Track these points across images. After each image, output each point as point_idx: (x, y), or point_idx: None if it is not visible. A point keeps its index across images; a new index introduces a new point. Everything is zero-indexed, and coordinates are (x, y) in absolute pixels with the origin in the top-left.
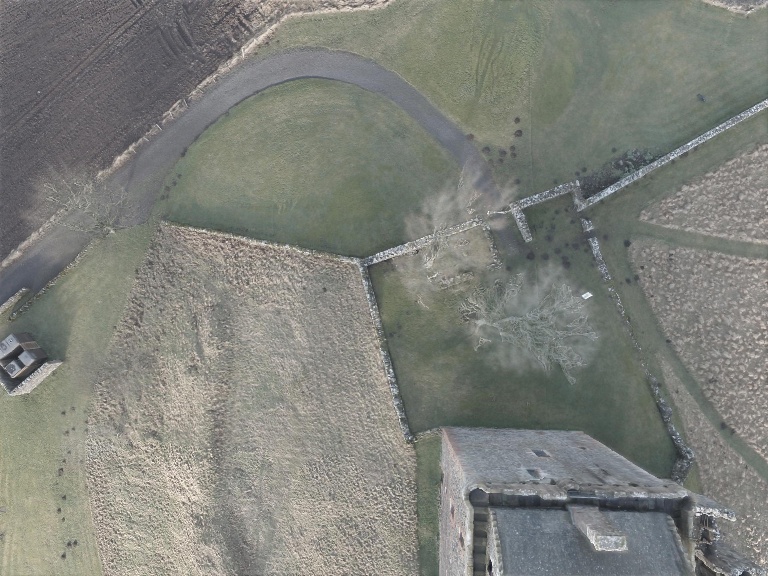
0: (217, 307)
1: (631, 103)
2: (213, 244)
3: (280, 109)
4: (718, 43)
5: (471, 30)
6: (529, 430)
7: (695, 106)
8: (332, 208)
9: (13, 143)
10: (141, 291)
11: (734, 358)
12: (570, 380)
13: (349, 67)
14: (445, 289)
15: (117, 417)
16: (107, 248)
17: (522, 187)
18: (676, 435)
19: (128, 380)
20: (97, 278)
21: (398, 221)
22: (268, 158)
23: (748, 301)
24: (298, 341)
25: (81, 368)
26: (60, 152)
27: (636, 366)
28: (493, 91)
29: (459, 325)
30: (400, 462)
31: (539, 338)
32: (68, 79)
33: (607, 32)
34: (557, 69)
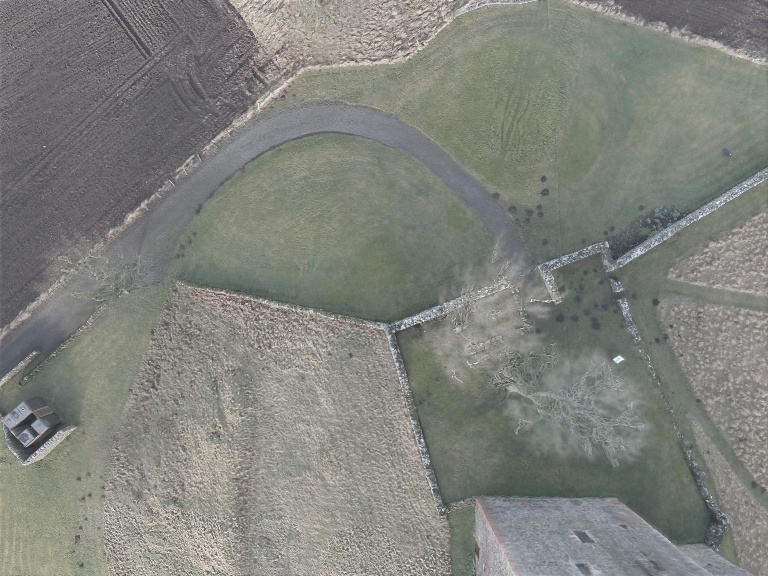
0: (238, 372)
1: (657, 159)
2: (232, 305)
3: (299, 165)
4: (743, 96)
5: (496, 87)
6: (563, 498)
7: (721, 161)
8: (356, 270)
9: (18, 200)
10: (157, 353)
11: (763, 415)
12: (613, 463)
13: (369, 122)
14: (474, 354)
15: (135, 482)
16: (121, 309)
17: (550, 247)
18: (710, 499)
19: (146, 445)
20: (111, 340)
21: (424, 283)
22: (288, 217)
23: None
24: (324, 408)
25: (96, 432)
26: (68, 209)
27: (668, 429)
28: (519, 149)
29: (489, 391)
30: (433, 533)
31: (584, 425)
32: (75, 133)
33: (632, 86)
34: (584, 126)
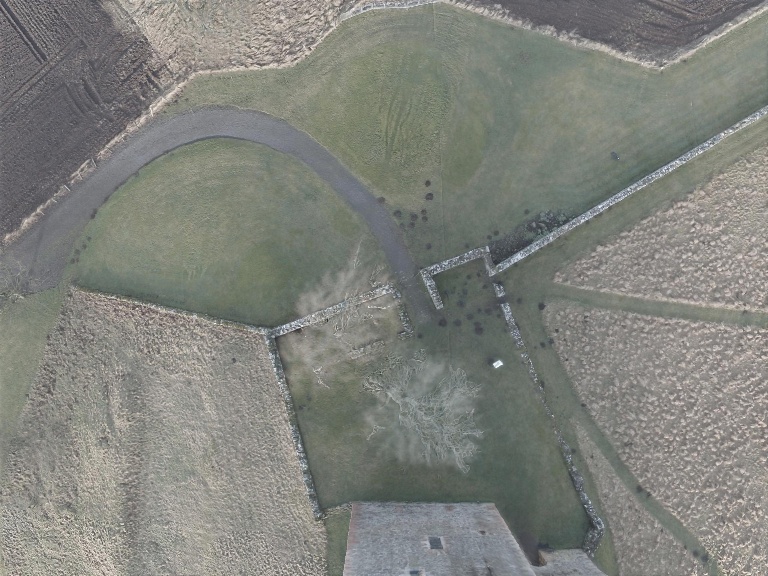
0: (128, 377)
1: (544, 163)
2: (124, 310)
3: (190, 170)
4: (632, 99)
5: (379, 91)
6: (439, 504)
7: (609, 164)
8: (241, 275)
9: None
10: (53, 358)
11: (650, 420)
12: (463, 469)
13: (259, 127)
14: (355, 359)
15: (32, 487)
16: (17, 314)
17: (434, 252)
18: (588, 504)
19: (42, 450)
20: (7, 345)
21: (309, 288)
22: (178, 222)
23: (664, 361)
24: (208, 413)
25: None
26: None
27: (549, 434)
28: (403, 153)
29: (370, 396)
30: (310, 539)
31: (426, 432)
32: None
33: (519, 90)
34: (467, 131)
